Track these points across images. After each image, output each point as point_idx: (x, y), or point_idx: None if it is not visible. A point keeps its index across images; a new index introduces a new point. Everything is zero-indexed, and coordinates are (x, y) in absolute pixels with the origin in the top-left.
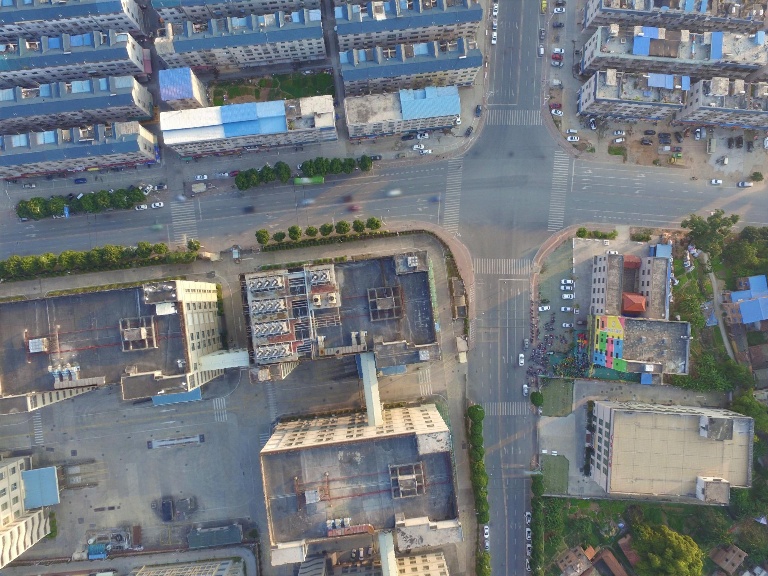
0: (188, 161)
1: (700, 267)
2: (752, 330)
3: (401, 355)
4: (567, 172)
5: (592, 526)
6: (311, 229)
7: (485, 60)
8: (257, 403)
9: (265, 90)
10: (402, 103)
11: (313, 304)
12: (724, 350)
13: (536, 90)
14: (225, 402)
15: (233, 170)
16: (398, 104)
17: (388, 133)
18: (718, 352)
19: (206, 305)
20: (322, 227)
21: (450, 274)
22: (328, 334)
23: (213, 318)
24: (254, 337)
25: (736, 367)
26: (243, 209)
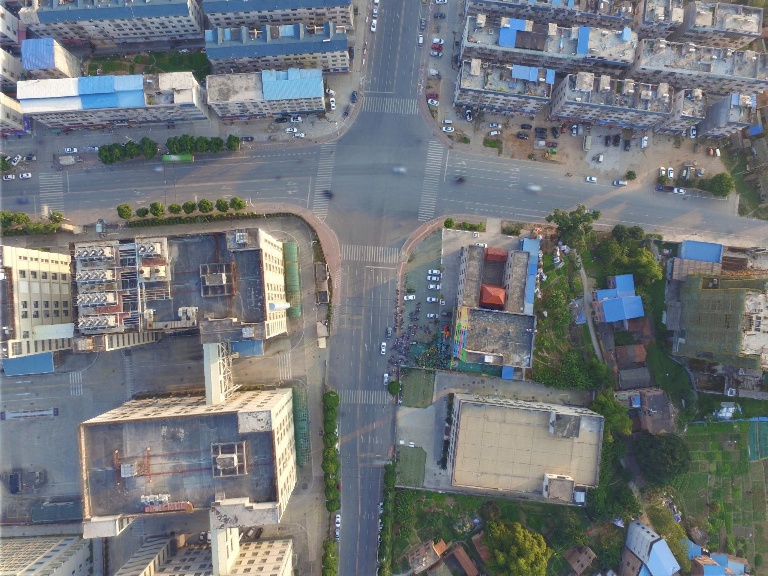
0: (58, 133)
1: (570, 264)
2: (621, 330)
3: (226, 332)
4: (441, 162)
5: (446, 520)
6: (173, 206)
7: (364, 47)
8: (114, 379)
9: (140, 66)
10: (264, 83)
11: (140, 276)
12: (592, 349)
13: (414, 79)
14: (81, 376)
15: (103, 144)
16: (260, 84)
17: (259, 114)
18: (586, 351)
19: (57, 276)
20: (184, 205)
21: (316, 259)
22: (159, 308)
23: (69, 290)
24: (81, 307)
25: (598, 366)
26: (111, 184)
